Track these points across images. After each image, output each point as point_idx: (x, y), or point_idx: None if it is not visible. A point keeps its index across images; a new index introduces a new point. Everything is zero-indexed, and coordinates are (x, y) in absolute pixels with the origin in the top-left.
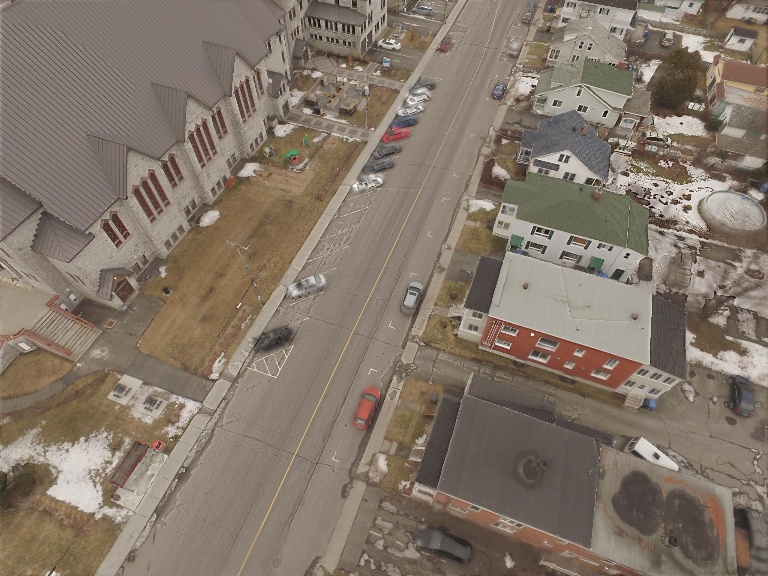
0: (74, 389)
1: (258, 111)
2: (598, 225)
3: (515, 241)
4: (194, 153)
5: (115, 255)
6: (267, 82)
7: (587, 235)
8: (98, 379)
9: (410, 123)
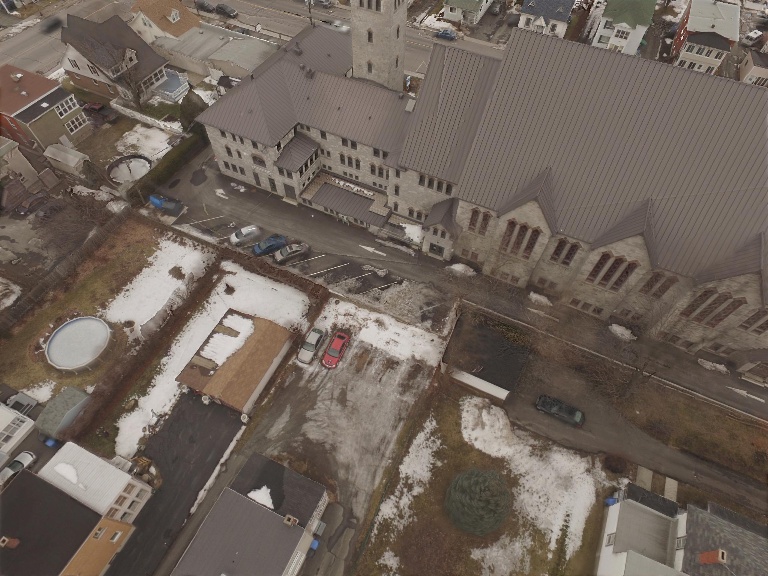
0: None
1: None
2: (649, 1)
3: (645, 42)
4: None
5: None
6: None
7: (654, 8)
8: None
9: None
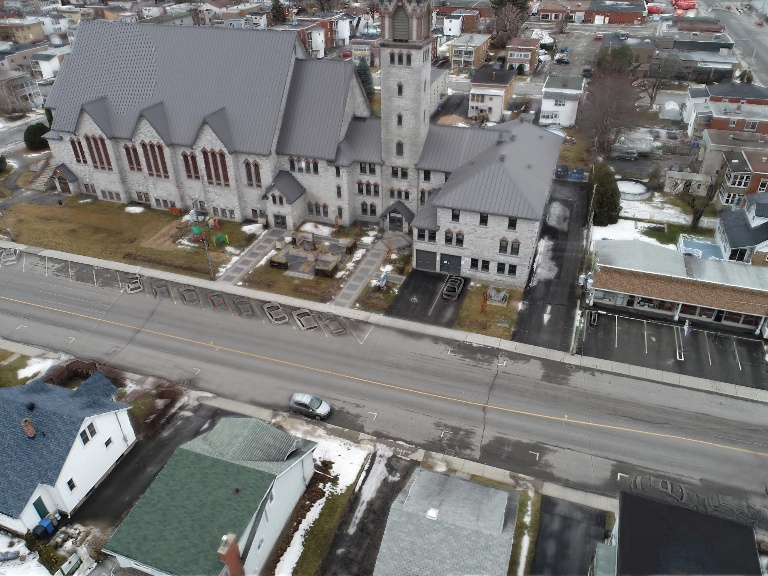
0: (5, 191)
1: (233, 190)
2: None
3: None
4: (145, 159)
5: (75, 165)
6: (270, 182)
7: None
8: (5, 196)
9: (245, 312)
